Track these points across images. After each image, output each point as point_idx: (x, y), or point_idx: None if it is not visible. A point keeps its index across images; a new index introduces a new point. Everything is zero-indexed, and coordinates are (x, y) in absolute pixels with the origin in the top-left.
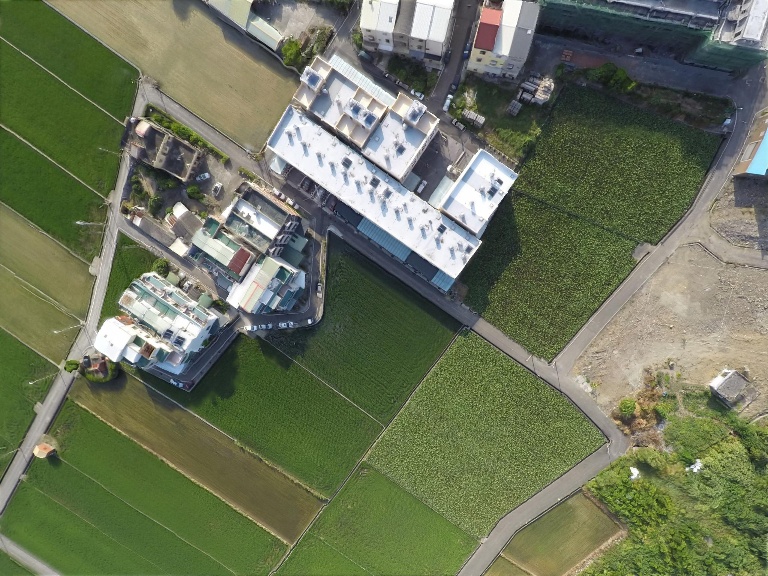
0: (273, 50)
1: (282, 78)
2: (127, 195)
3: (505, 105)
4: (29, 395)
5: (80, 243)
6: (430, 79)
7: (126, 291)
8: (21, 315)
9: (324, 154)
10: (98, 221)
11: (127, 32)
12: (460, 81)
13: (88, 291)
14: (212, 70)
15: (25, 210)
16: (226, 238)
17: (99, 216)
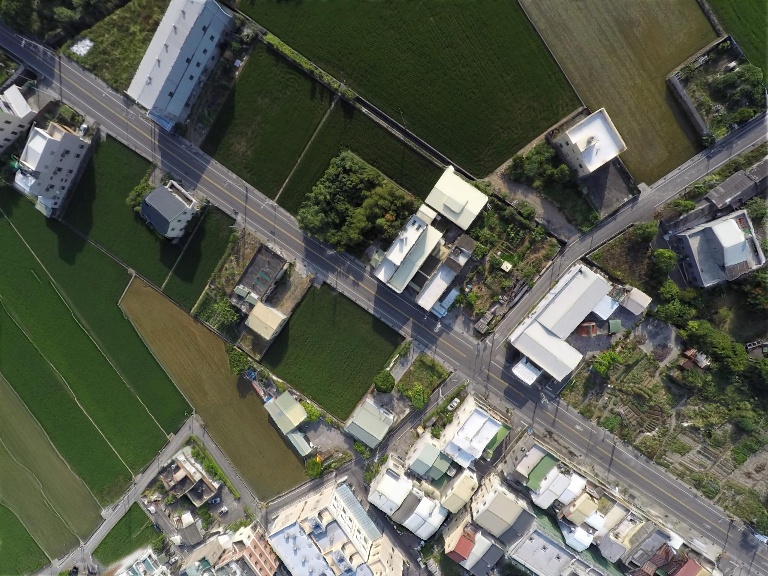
0: (301, 454)
1: (302, 465)
2: (151, 487)
3: (461, 567)
4: (20, 568)
5: (101, 493)
6: (411, 532)
7: (123, 575)
8: (36, 515)
9: (308, 560)
10: (121, 488)
11: (195, 381)
12: (434, 538)
13: (95, 525)
14: (250, 435)
15: (67, 453)
16: (213, 575)
17: (124, 483)
